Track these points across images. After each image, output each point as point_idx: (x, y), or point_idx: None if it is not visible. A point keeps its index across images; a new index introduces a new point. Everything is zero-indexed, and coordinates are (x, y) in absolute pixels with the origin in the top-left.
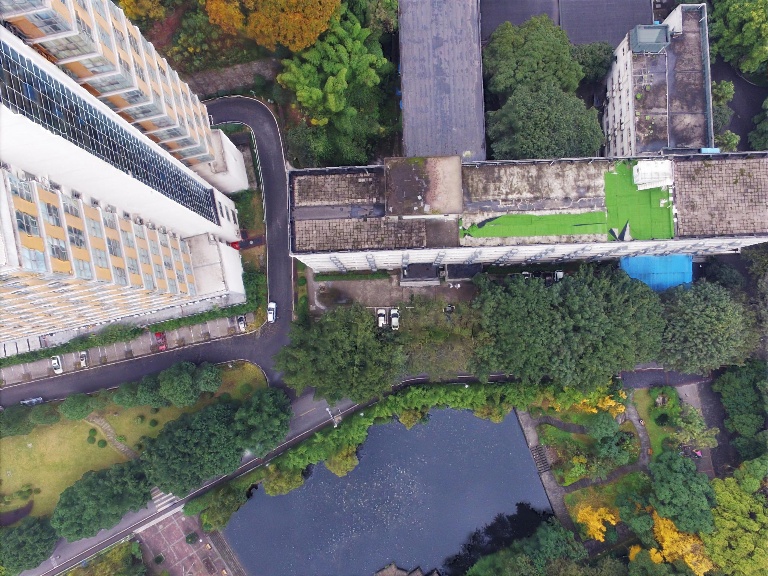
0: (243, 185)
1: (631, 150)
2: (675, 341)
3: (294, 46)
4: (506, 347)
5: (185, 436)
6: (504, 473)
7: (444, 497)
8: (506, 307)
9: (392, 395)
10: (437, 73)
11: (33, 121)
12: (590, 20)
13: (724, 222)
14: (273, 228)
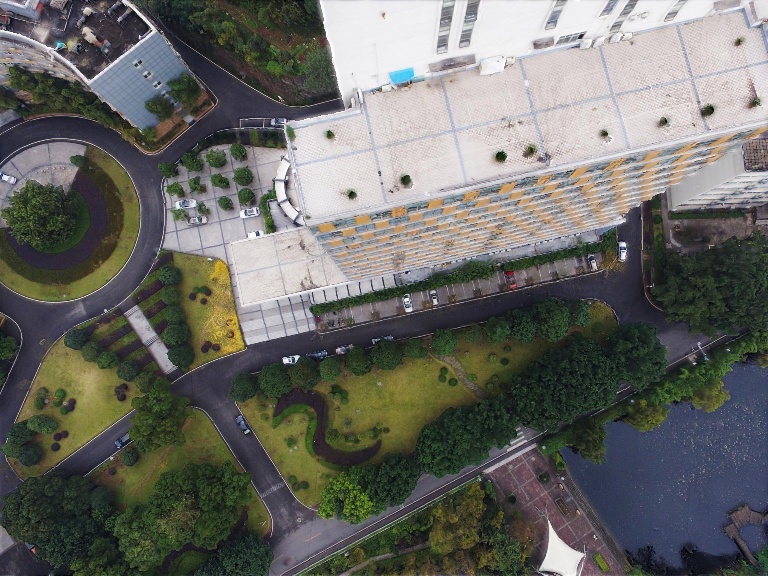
0: None
1: None
2: None
3: None
4: None
5: (569, 367)
6: None
7: None
8: None
9: None
10: None
11: None
12: None
13: None
14: None
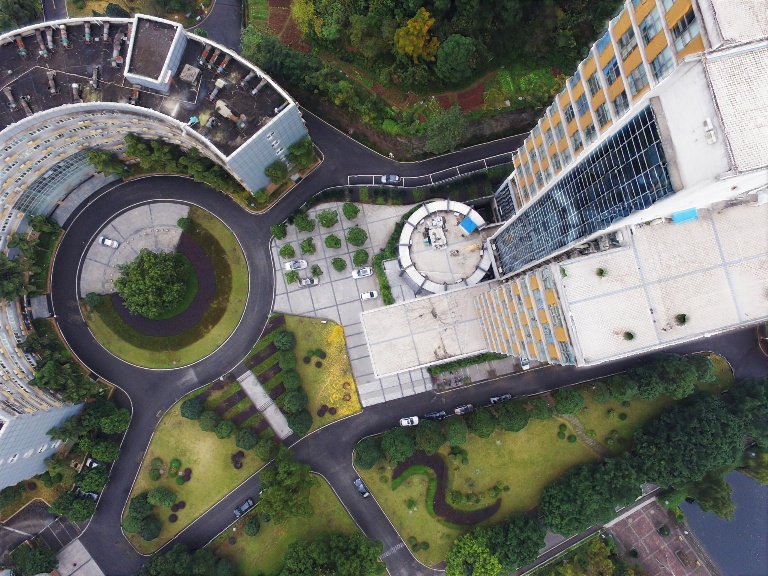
0: None
1: None
2: None
3: None
4: None
5: (699, 427)
6: None
7: None
8: None
9: None
10: None
11: None
12: None
13: None
14: None
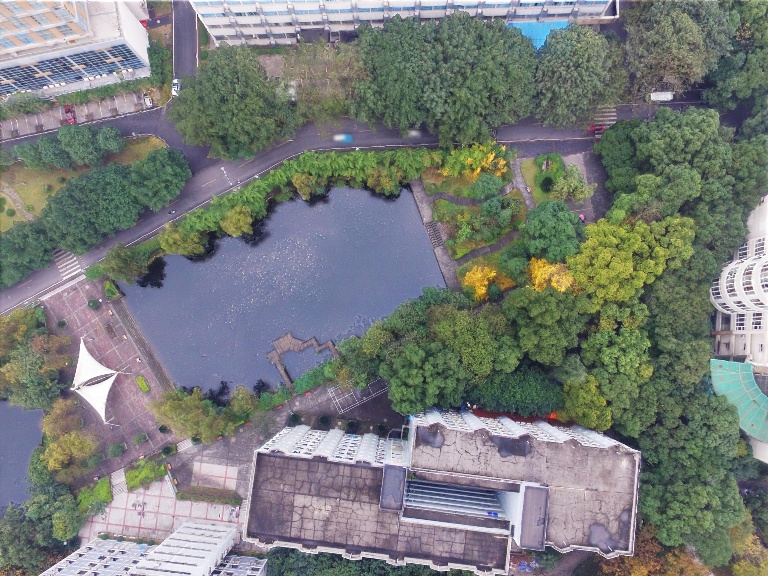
0: None
1: None
2: (545, 79)
3: None
4: (381, 79)
5: (82, 184)
6: (399, 248)
7: (340, 270)
8: (381, 42)
9: (287, 160)
10: None
11: None
12: None
13: None
14: (179, 8)
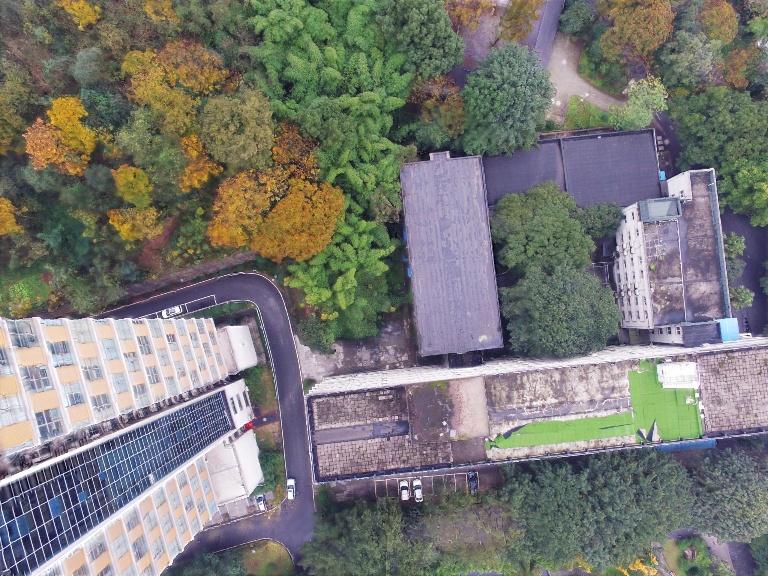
0: (252, 365)
1: (648, 322)
2: (705, 516)
3: (301, 258)
4: (538, 540)
5: None
6: None
7: None
8: (535, 499)
9: None
10: (447, 256)
11: (58, 543)
12: (596, 178)
13: (751, 415)
14: (286, 404)
